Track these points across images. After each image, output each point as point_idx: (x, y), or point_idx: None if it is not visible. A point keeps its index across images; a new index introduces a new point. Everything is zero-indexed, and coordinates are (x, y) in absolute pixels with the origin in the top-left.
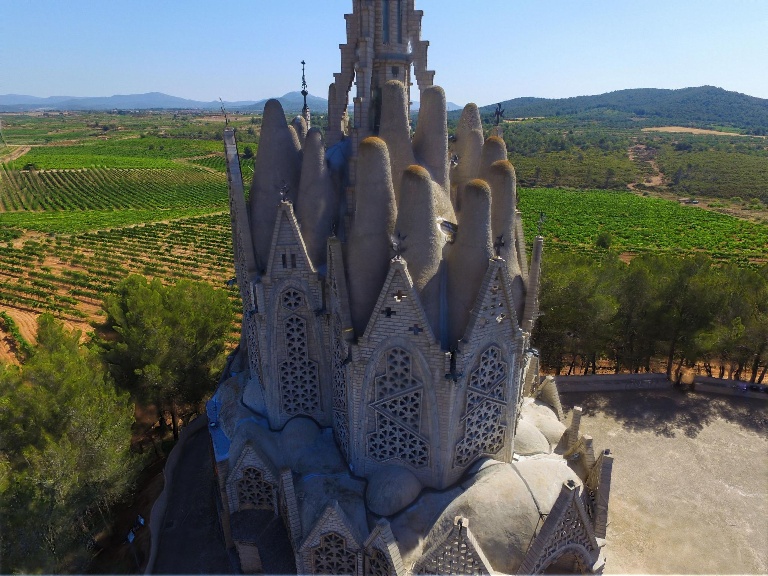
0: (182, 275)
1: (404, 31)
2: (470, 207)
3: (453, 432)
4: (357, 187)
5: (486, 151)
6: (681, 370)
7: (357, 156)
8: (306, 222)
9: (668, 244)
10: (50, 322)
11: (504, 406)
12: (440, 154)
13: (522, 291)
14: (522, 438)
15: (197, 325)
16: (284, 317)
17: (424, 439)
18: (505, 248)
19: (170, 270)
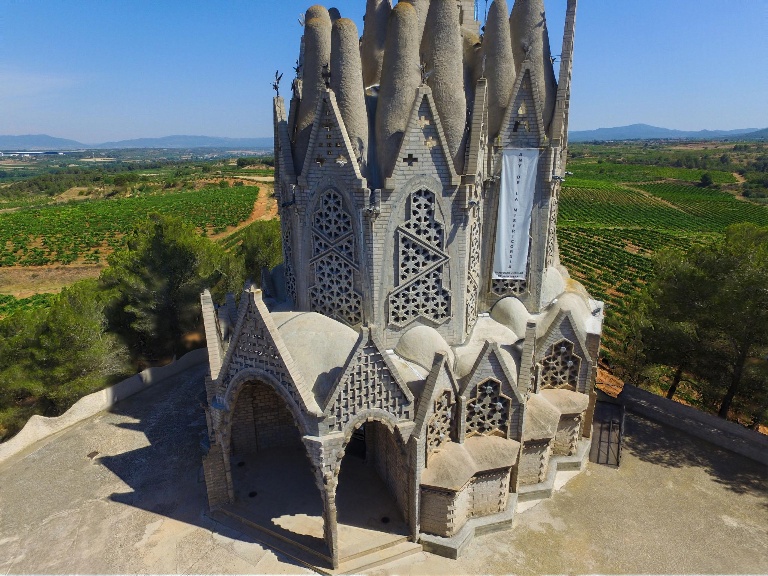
0: None
1: None
2: None
3: (305, 273)
4: None
5: None
6: None
7: None
8: None
9: None
10: None
11: (355, 269)
12: None
13: (398, 148)
14: (408, 339)
15: None
16: None
17: (294, 275)
18: (388, 98)
19: None
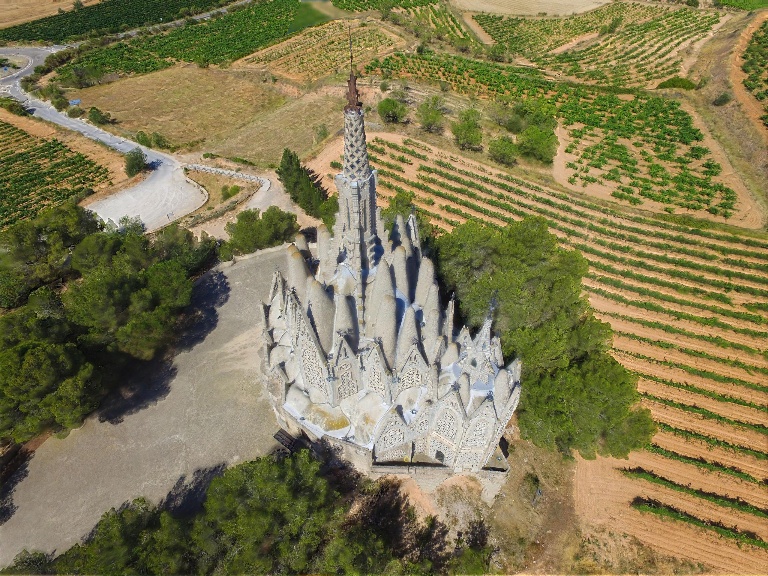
0: None
1: None
2: None
3: None
4: None
5: None
6: None
7: None
8: None
9: None
10: (596, 324)
11: None
12: None
13: None
14: None
15: (533, 377)
16: None
17: None
18: None
19: None
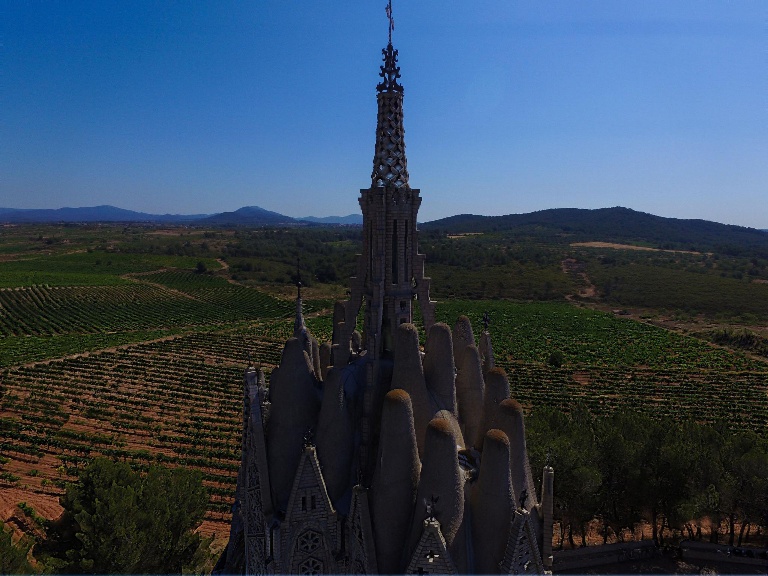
0: (131, 417)
1: (409, 271)
2: (492, 459)
3: None
4: (383, 437)
5: (491, 382)
6: (665, 531)
7: (372, 386)
8: (326, 459)
9: (613, 360)
10: None
11: None
12: (449, 384)
13: (539, 524)
14: None
15: (170, 520)
16: (300, 561)
17: None
18: (520, 483)
19: (117, 411)
